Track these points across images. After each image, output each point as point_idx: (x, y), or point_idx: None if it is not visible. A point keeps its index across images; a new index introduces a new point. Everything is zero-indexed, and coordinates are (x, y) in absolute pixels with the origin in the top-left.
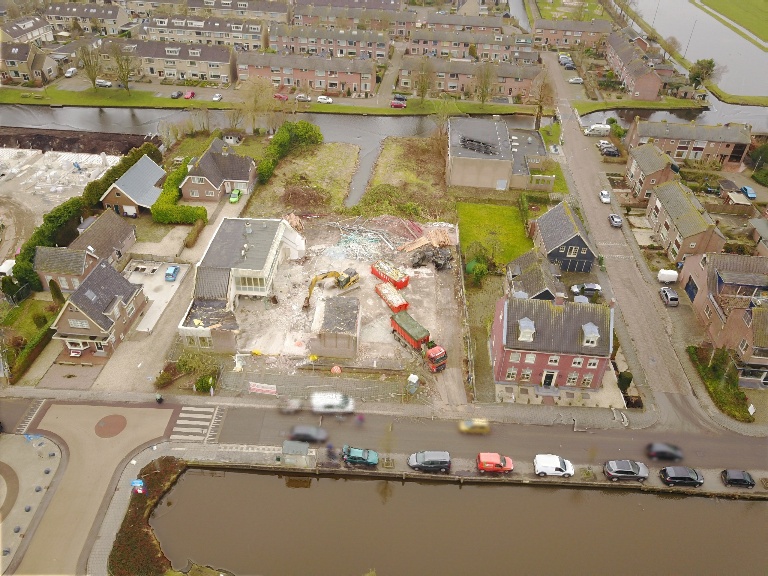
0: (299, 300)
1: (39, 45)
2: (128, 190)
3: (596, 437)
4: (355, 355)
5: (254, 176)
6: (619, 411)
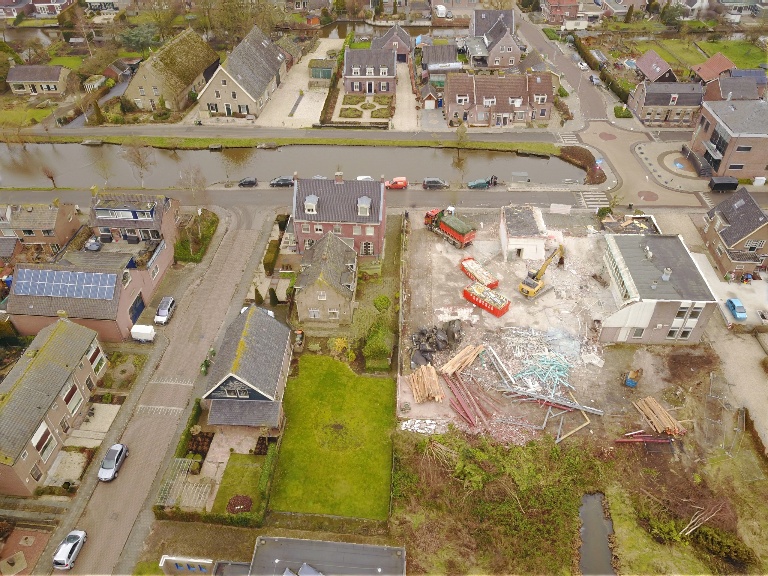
0: (574, 279)
1: None
2: None
3: None
4: None
5: None
6: None
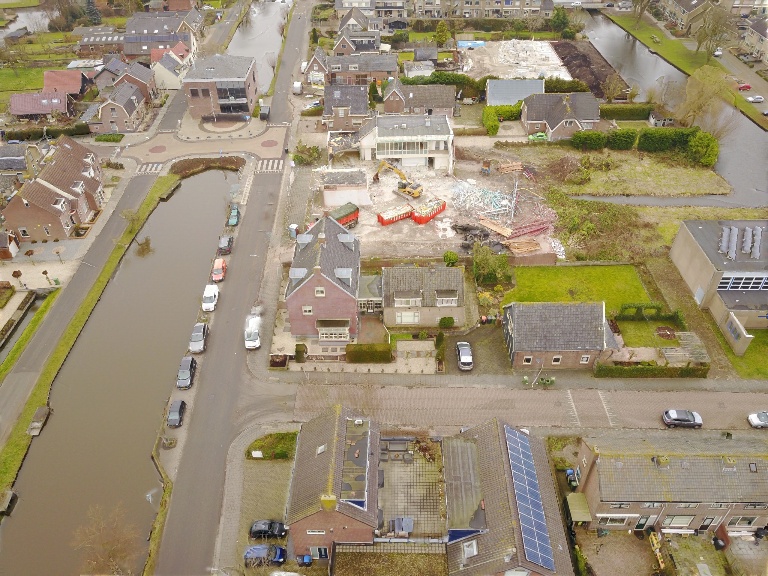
0: (390, 180)
1: (764, 13)
2: (493, 89)
3: (240, 330)
4: (321, 203)
5: (571, 135)
6: (258, 338)
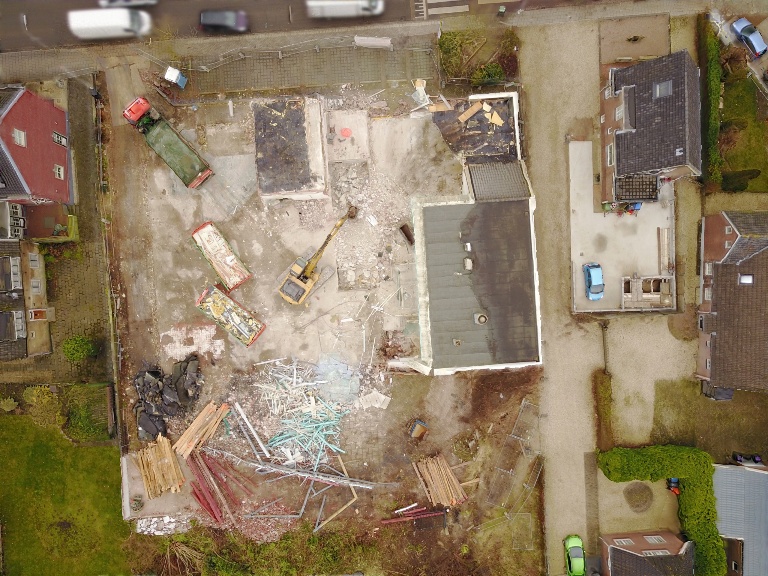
0: (370, 240)
1: None
2: None
3: None
4: None
5: None
6: None
